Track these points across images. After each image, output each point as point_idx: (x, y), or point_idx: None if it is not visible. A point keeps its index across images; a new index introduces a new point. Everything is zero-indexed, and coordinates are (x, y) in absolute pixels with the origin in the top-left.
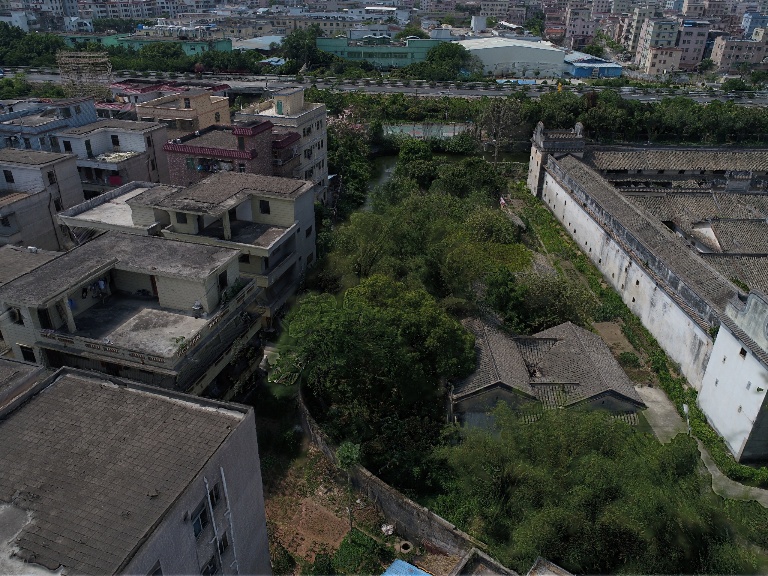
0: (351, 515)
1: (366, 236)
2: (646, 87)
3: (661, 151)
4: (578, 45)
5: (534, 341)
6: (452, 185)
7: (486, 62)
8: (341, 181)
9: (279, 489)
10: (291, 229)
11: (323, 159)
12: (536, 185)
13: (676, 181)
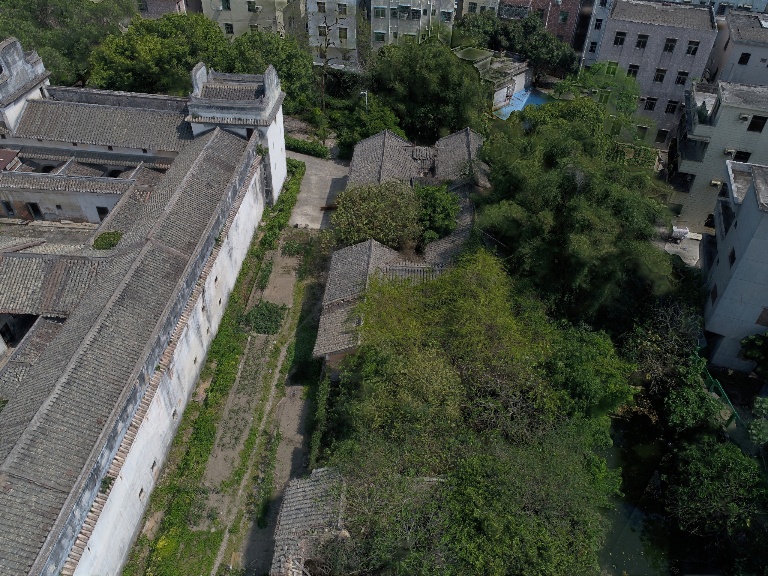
0: None
1: None
2: None
3: None
4: None
5: None
6: None
7: None
8: None
9: None
10: None
11: None
12: None
13: None
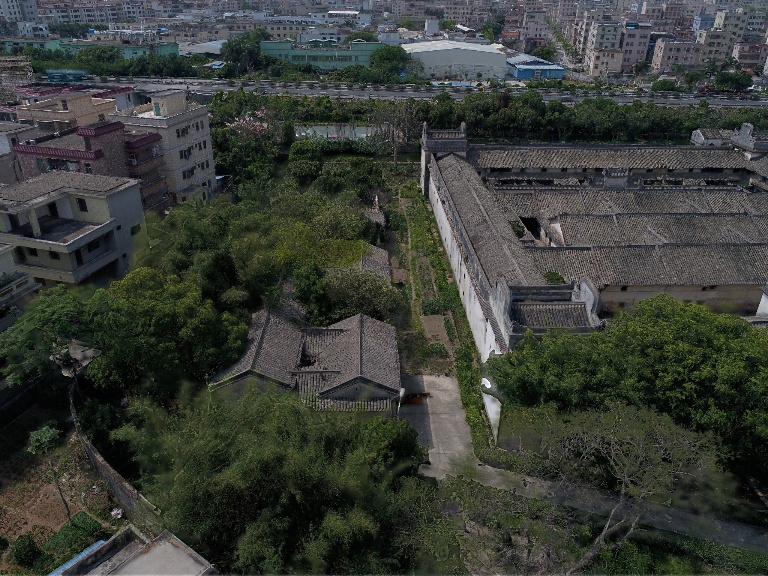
0: (84, 500)
1: (175, 232)
2: (578, 88)
3: (545, 150)
4: (530, 48)
5: (320, 332)
6: (326, 184)
7: (429, 65)
8: (231, 181)
9: (26, 476)
10: (103, 226)
11: (207, 160)
12: (423, 184)
13: (558, 179)
